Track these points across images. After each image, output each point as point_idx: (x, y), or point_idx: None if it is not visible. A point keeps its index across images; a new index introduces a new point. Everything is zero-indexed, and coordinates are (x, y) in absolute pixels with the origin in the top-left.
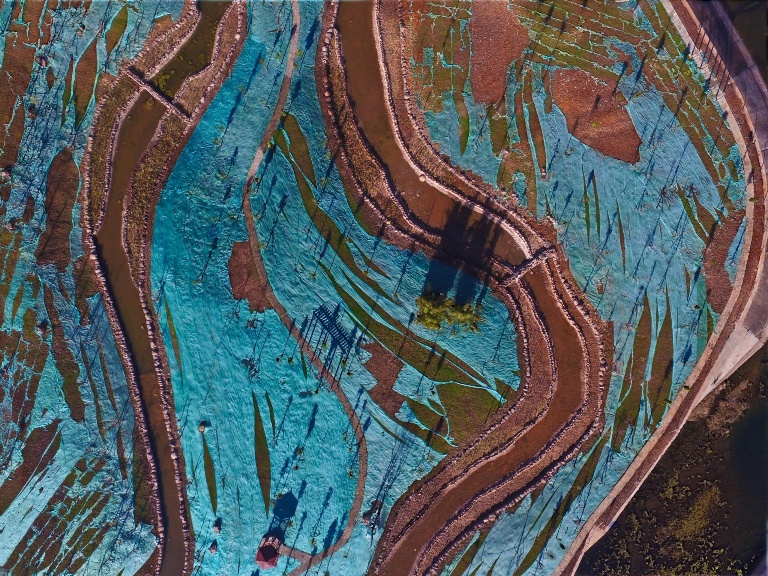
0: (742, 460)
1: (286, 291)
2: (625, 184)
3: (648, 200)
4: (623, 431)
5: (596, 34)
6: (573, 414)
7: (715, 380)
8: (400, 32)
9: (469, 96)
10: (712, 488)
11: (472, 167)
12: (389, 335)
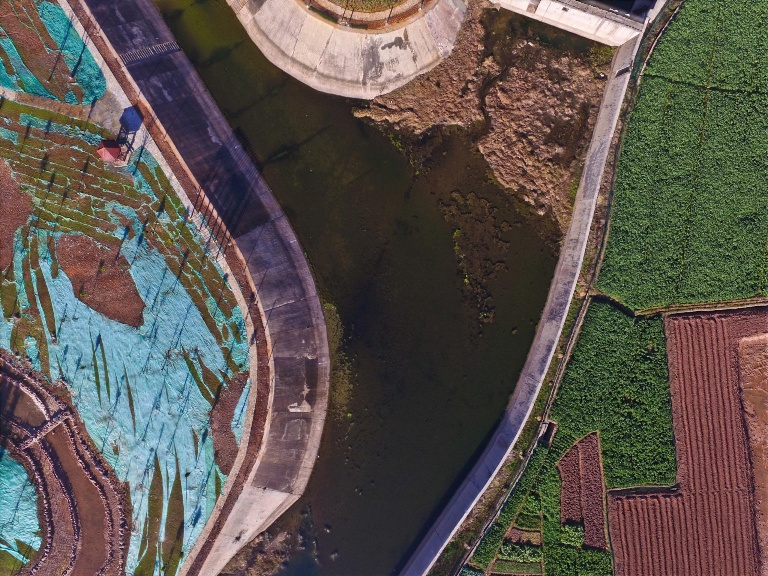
0: None
1: None
2: (130, 347)
3: (154, 363)
4: None
5: (98, 199)
6: (98, 572)
7: (238, 537)
8: None
9: None
10: None
11: None
12: None
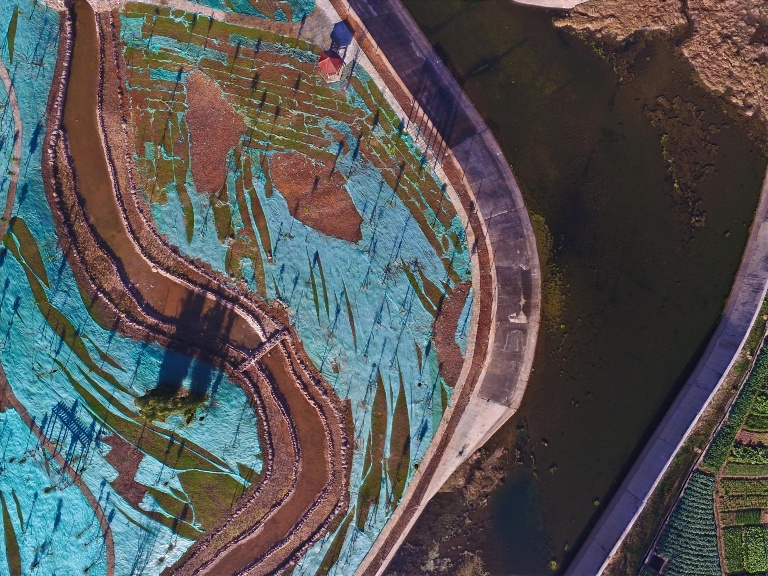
0: (506, 528)
1: (25, 390)
2: (349, 263)
3: (373, 277)
4: (366, 509)
5: (310, 116)
6: (319, 493)
7: (460, 452)
8: (123, 128)
9: (191, 186)
10: (473, 559)
11: (200, 255)
12: (127, 427)
